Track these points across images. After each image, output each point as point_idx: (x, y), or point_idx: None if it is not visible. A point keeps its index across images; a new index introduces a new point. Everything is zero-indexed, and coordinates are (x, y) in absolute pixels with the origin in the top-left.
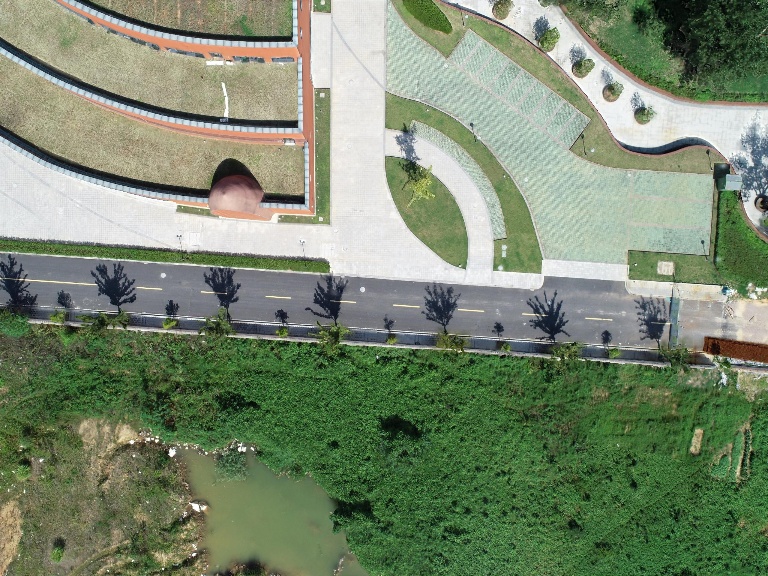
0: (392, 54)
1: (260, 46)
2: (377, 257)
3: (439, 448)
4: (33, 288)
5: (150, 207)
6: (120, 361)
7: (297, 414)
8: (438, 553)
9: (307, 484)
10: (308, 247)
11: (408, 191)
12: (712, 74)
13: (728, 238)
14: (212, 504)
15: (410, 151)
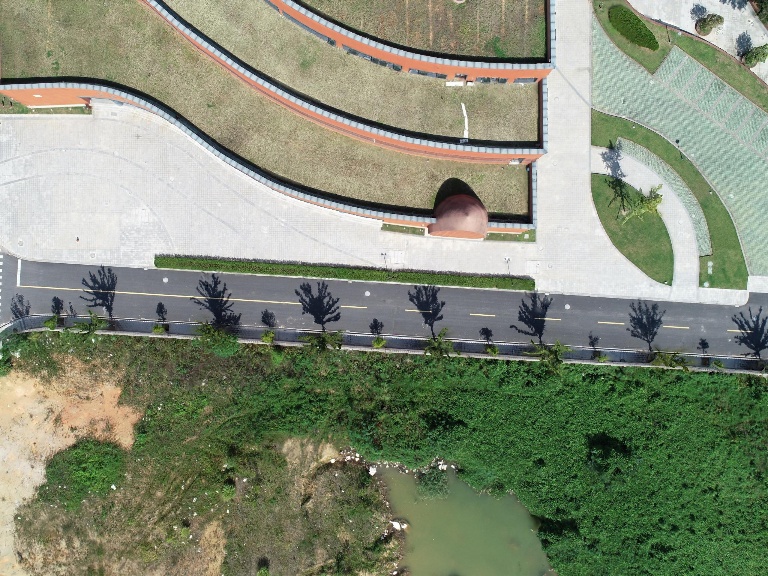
0: (597, 71)
1: (518, 68)
2: (582, 274)
3: (646, 465)
4: (237, 307)
5: (355, 225)
6: (325, 380)
7: (504, 432)
8: (645, 570)
9: (507, 502)
10: (513, 265)
11: (614, 208)
12: None
13: None
14: (412, 522)
15: (616, 168)
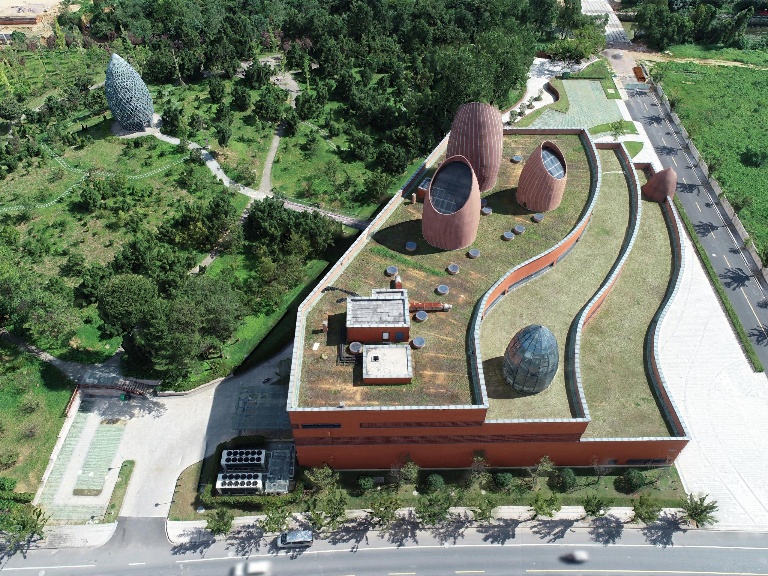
0: None
1: None
2: None
3: None
4: (765, 322)
5: None
6: None
7: (766, 196)
8: None
9: None
10: None
11: None
12: (532, 61)
13: (590, 75)
14: None
15: None
